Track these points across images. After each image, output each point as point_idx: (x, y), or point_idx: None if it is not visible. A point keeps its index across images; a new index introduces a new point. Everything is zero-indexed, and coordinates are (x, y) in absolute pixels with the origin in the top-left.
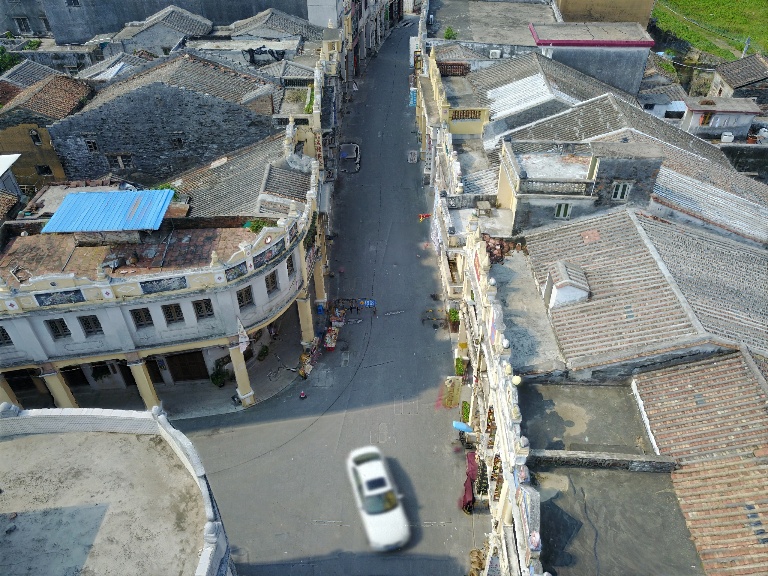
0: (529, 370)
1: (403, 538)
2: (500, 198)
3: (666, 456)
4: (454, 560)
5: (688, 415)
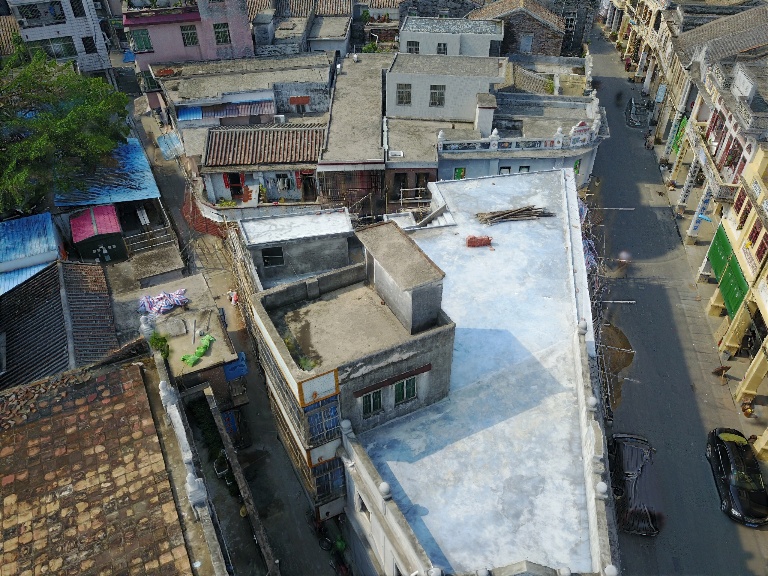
0: None
1: (603, 74)
2: None
3: None
4: None
5: None
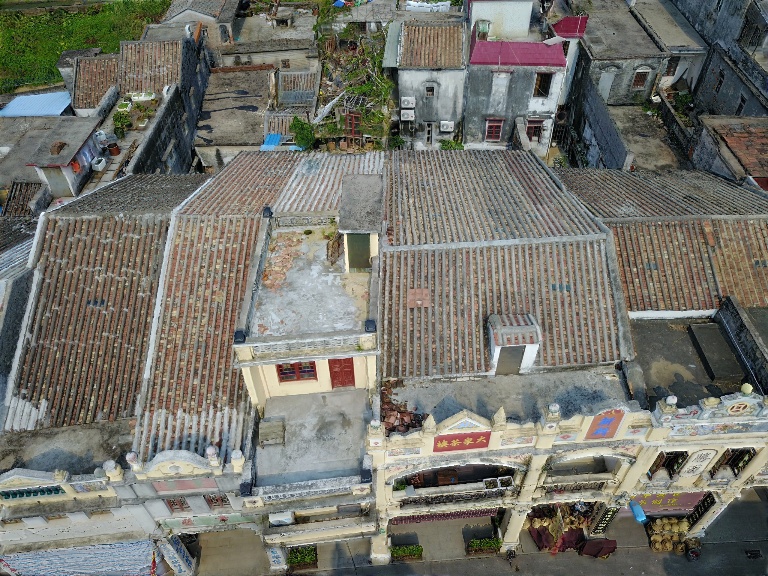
0: (645, 397)
1: None
2: (261, 403)
3: (733, 300)
4: (669, 570)
5: (669, 279)
